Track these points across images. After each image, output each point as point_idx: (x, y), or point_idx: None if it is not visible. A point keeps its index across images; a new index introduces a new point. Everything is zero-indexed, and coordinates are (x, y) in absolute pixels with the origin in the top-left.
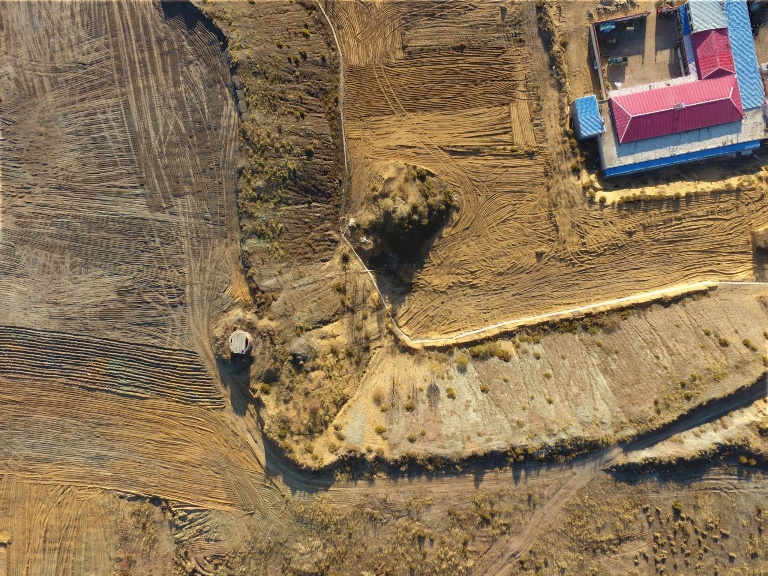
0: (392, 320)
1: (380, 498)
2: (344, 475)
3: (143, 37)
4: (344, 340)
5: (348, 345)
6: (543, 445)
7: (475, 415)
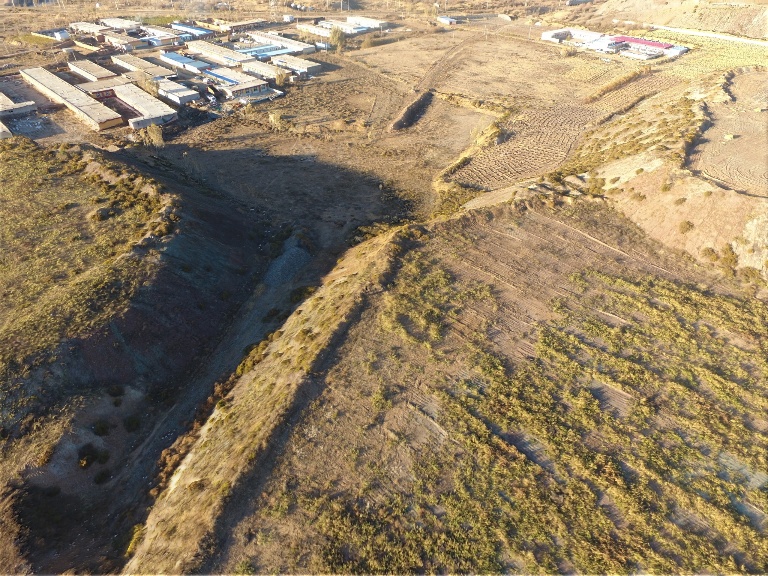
0: None
1: None
2: None
3: None
4: None
5: None
6: None
7: None
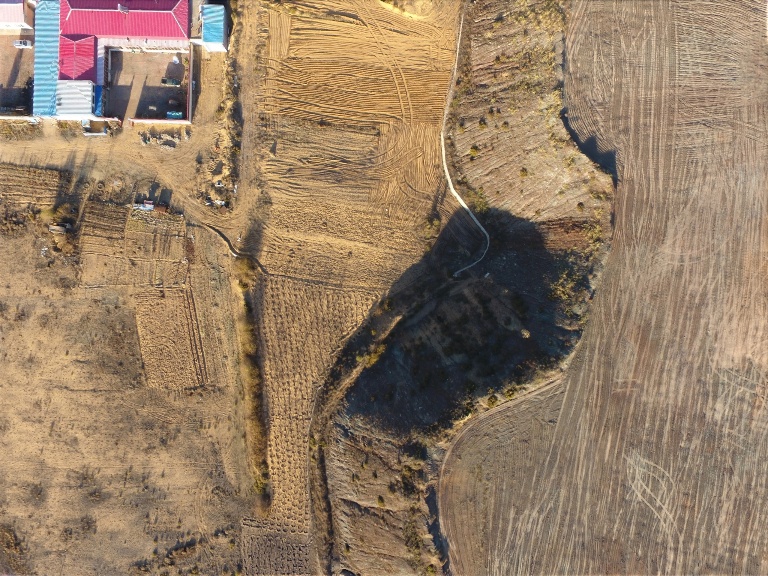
0: None
1: None
2: None
3: (641, 138)
4: None
5: None
6: None
7: None
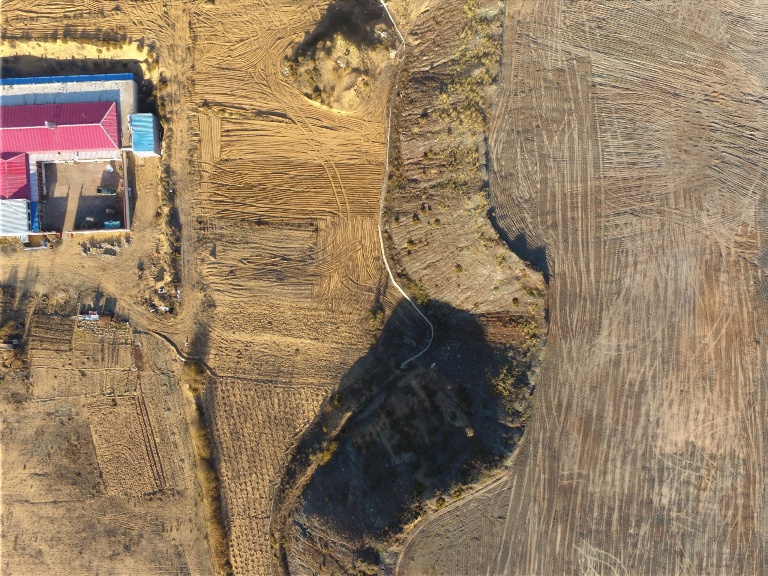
0: None
1: None
2: None
3: (570, 232)
4: None
5: None
6: None
7: None
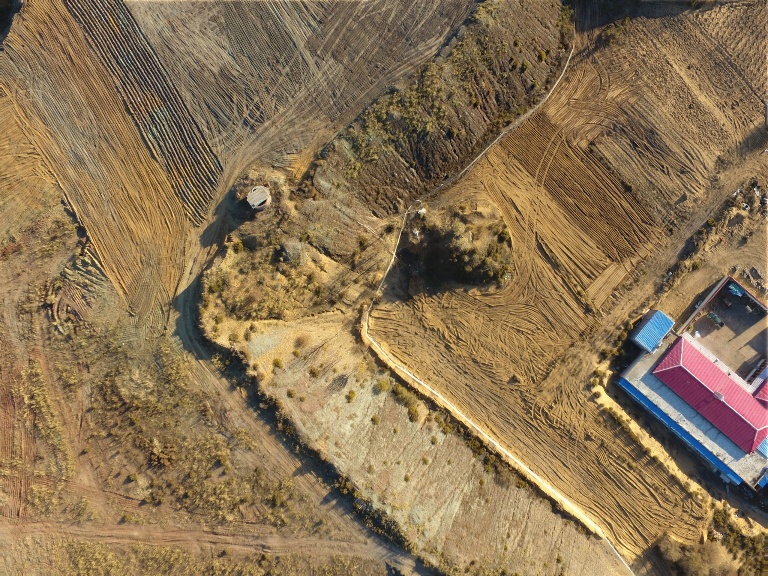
0: (371, 305)
1: (224, 406)
2: (220, 363)
3: None
4: (325, 279)
5: (324, 285)
6: (368, 500)
7: (349, 429)
